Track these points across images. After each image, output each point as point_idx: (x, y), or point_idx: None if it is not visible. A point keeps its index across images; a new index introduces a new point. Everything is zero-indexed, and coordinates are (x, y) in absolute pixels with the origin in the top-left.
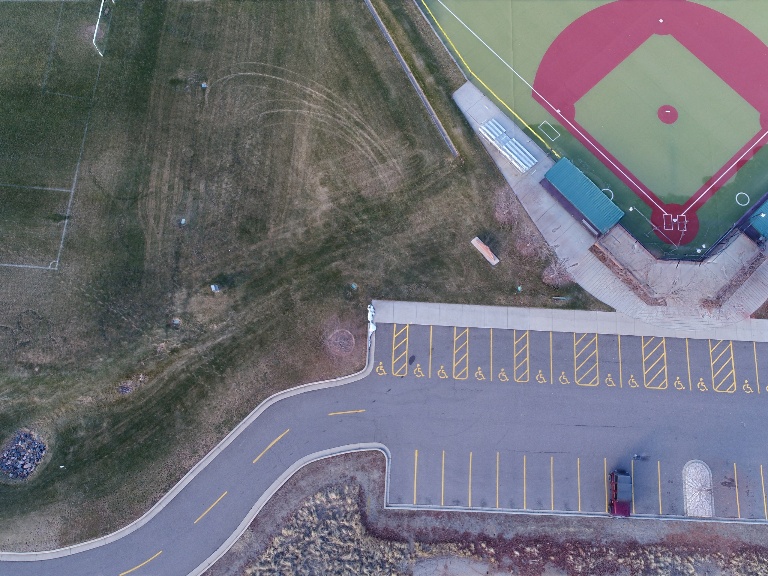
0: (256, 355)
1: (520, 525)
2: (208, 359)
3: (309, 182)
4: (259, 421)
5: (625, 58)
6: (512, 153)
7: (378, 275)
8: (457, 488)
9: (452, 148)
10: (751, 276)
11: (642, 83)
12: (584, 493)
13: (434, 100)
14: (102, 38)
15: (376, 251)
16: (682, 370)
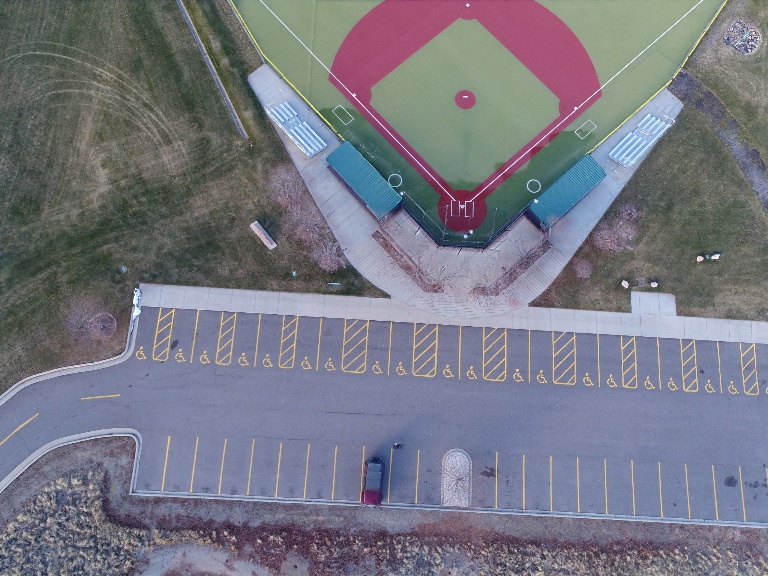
0: (13, 338)
1: (268, 513)
2: None
3: (90, 163)
4: (8, 405)
5: (427, 42)
6: (300, 137)
7: (149, 258)
8: (208, 475)
9: (242, 131)
10: (534, 264)
11: (442, 68)
12: (339, 481)
13: (227, 82)
14: None
15: (151, 234)
16: (453, 358)
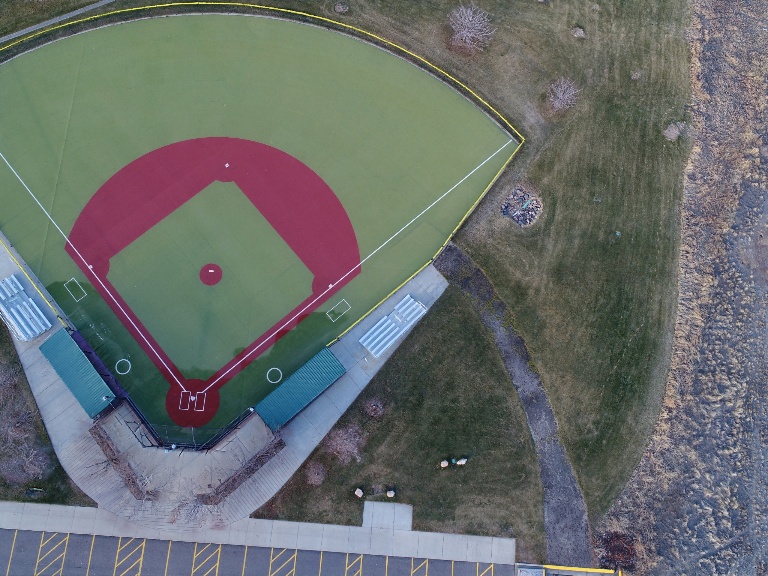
0: None
1: None
2: None
3: None
4: None
5: (177, 207)
6: None
7: None
8: None
9: None
10: (262, 467)
11: (190, 237)
12: None
13: None
14: None
15: None
16: None
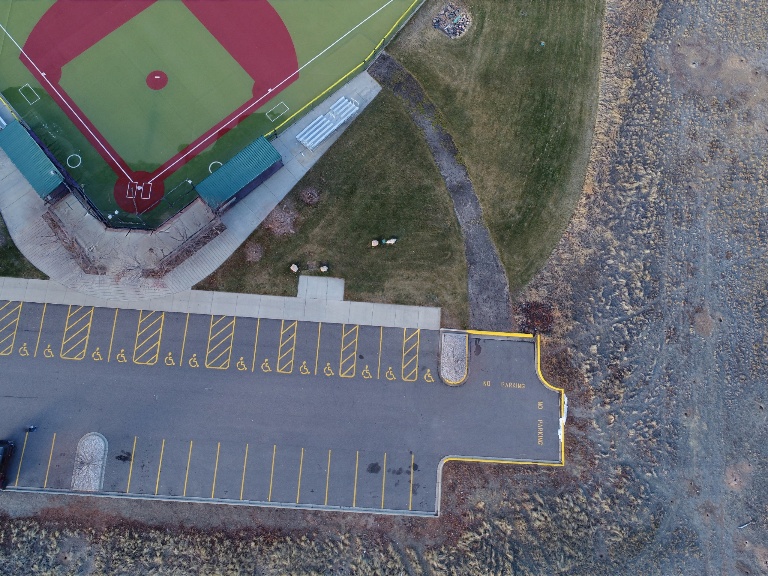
0: None
1: None
2: None
3: None
4: None
5: (126, 22)
6: None
7: None
8: None
9: None
10: (204, 246)
11: (137, 48)
12: None
13: None
14: None
15: None
16: (104, 341)
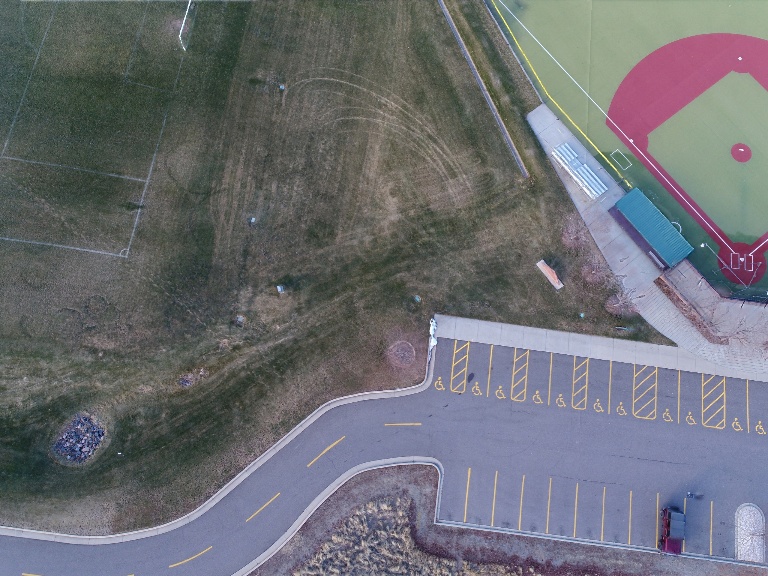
0: (317, 359)
1: (569, 553)
2: (269, 359)
3: (379, 191)
4: (316, 425)
5: (702, 93)
6: (583, 179)
7: (442, 290)
8: (508, 510)
9: (523, 169)
10: None
11: (717, 119)
12: (635, 527)
13: (508, 120)
14: (186, 33)
15: (441, 265)
16: (741, 411)
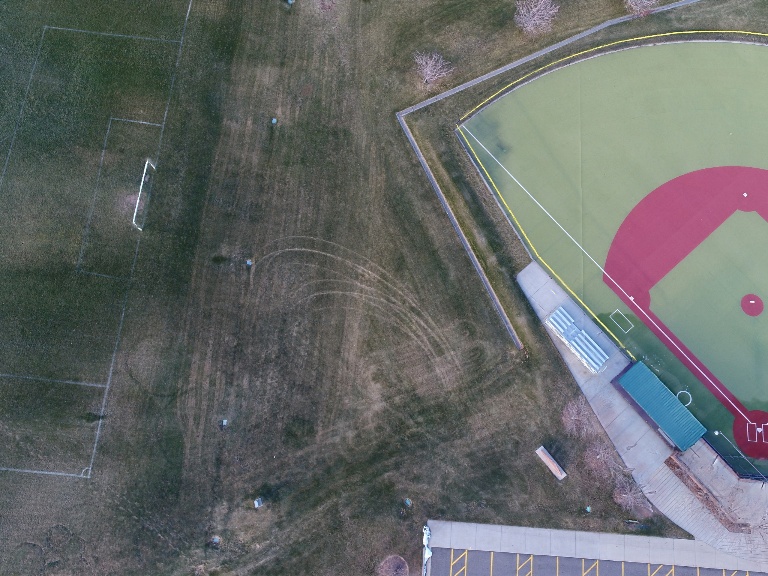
0: None
1: None
2: None
3: (360, 377)
4: None
5: (705, 238)
6: (582, 349)
7: (434, 490)
8: None
9: (515, 339)
10: None
11: (724, 268)
12: None
13: (496, 283)
14: (142, 210)
15: (432, 461)
16: None
